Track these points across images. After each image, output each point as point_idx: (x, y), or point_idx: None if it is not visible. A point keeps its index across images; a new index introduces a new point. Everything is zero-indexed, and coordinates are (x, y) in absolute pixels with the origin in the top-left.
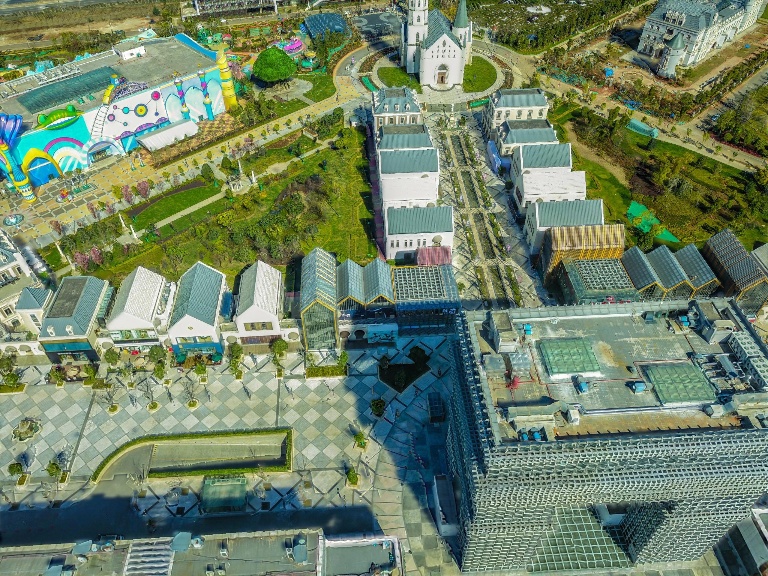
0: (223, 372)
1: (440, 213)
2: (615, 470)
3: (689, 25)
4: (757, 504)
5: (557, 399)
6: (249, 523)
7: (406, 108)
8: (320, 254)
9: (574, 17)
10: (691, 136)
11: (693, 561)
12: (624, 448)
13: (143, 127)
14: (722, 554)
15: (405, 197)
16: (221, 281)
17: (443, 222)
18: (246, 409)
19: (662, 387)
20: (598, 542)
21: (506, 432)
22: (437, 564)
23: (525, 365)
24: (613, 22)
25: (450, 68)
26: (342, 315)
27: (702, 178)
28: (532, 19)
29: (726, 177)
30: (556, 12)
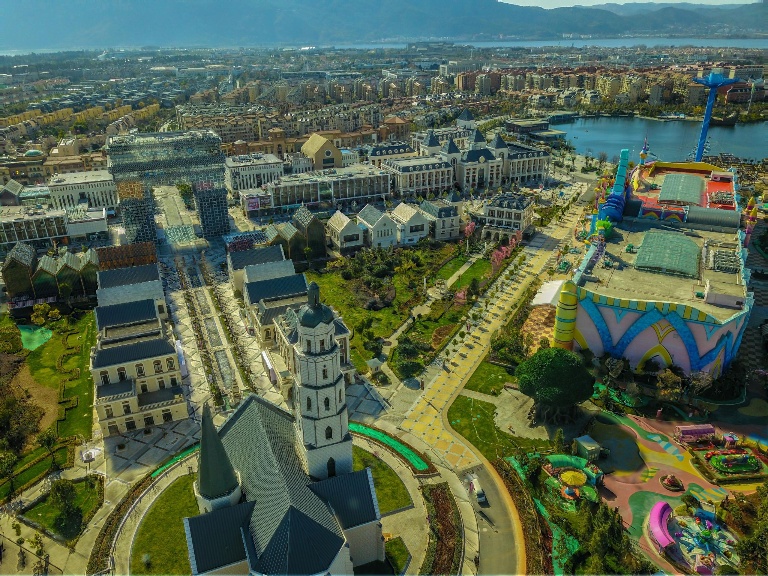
0: None
1: None
2: None
3: None
4: None
5: None
6: None
7: None
8: None
9: None
10: None
11: None
12: None
13: None
14: None
15: None
16: None
17: None
18: None
19: None
20: None
21: None
22: None
23: None
24: None
25: None
26: None
27: None
28: None
29: None
30: None
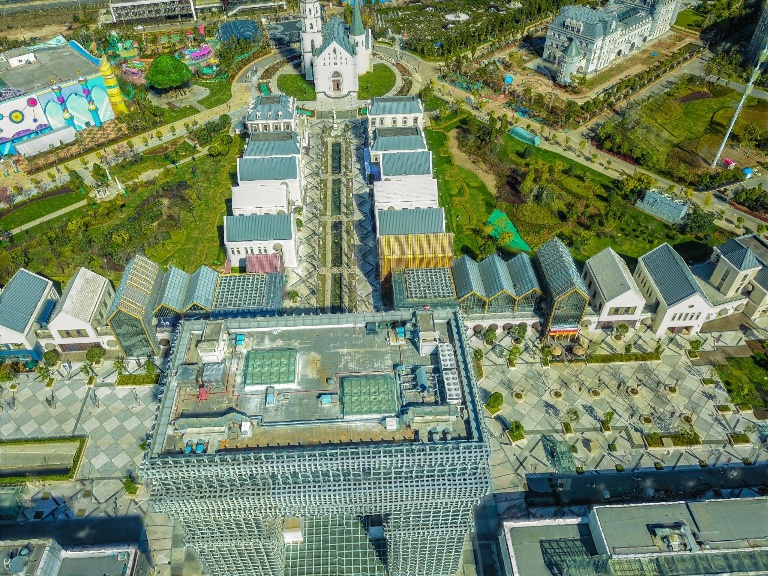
0: (36, 379)
1: (279, 221)
2: (296, 483)
3: (586, 33)
4: (533, 517)
5: (242, 411)
6: (17, 532)
7: (279, 115)
8: (139, 261)
9: (483, 25)
10: (573, 144)
11: (451, 575)
12: (283, 461)
13: (21, 133)
14: (483, 568)
15: (255, 204)
16: (45, 288)
17: (282, 230)
18: (48, 417)
19: (349, 399)
20: (361, 555)
21: (175, 444)
22: (194, 575)
23: (216, 376)
24: (523, 30)
25: (344, 75)
26: (161, 323)
27: (571, 186)
28: (447, 26)
29: (595, 185)
30: (473, 19)
